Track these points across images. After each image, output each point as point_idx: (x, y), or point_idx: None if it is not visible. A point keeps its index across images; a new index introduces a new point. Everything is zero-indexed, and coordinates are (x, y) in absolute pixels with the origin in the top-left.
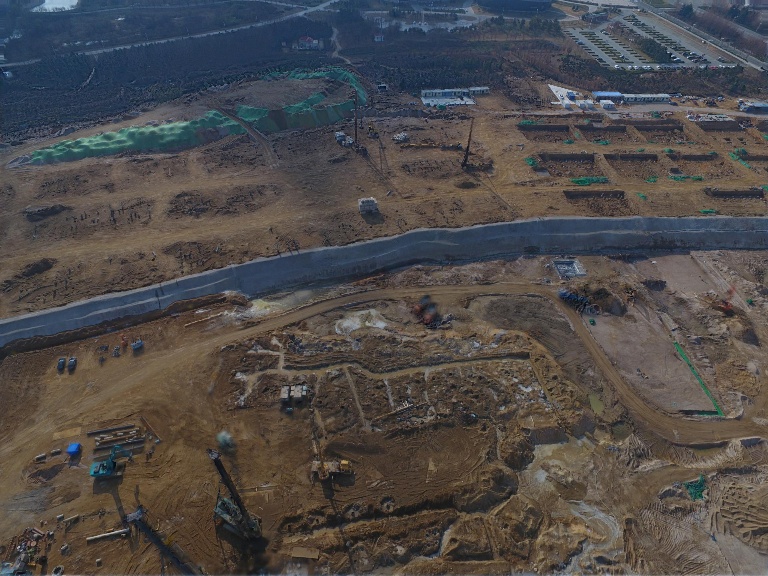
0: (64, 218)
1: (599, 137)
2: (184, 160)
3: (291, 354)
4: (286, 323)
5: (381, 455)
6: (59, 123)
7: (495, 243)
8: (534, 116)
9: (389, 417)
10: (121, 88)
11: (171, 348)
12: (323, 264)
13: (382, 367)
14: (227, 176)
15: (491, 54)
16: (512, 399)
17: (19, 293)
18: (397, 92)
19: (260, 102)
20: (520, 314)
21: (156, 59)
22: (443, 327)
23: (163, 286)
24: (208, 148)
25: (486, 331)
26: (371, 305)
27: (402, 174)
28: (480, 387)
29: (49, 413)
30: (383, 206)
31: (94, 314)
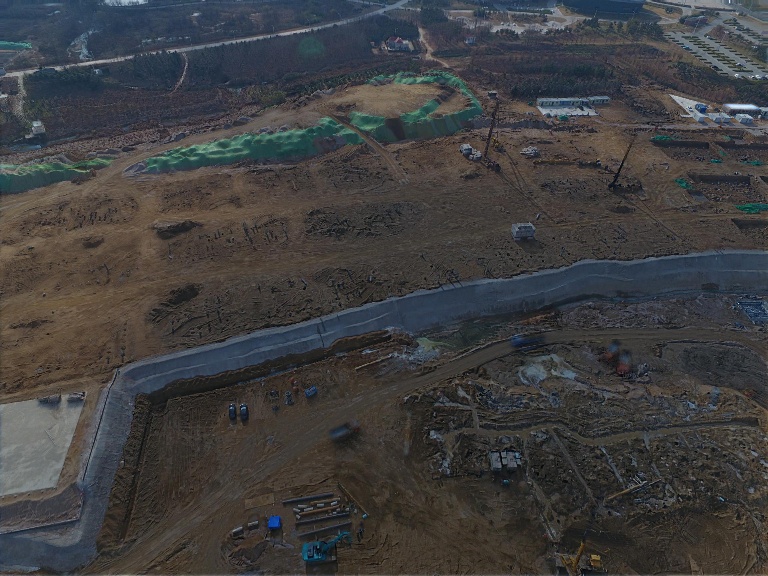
0: (196, 236)
1: (744, 156)
2: (306, 172)
3: (484, 409)
4: (464, 369)
5: (630, 547)
6: (162, 127)
7: (670, 279)
8: (667, 130)
9: (624, 497)
10: (218, 89)
11: (348, 396)
12: (488, 299)
13: (593, 430)
14: (356, 192)
15: (595, 59)
16: (759, 479)
17: (171, 324)
18: (509, 100)
19: (373, 109)
20: (724, 367)
21: (251, 59)
22: (643, 381)
23: (324, 321)
24: (328, 159)
25: (693, 387)
26: (551, 349)
27: (545, 194)
28: (717, 462)
29: (233, 474)
30: (537, 232)
31: (256, 352)
